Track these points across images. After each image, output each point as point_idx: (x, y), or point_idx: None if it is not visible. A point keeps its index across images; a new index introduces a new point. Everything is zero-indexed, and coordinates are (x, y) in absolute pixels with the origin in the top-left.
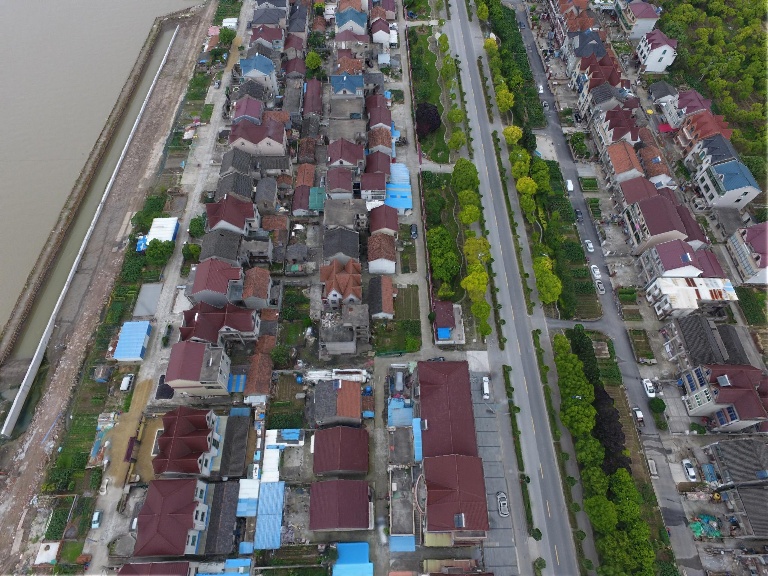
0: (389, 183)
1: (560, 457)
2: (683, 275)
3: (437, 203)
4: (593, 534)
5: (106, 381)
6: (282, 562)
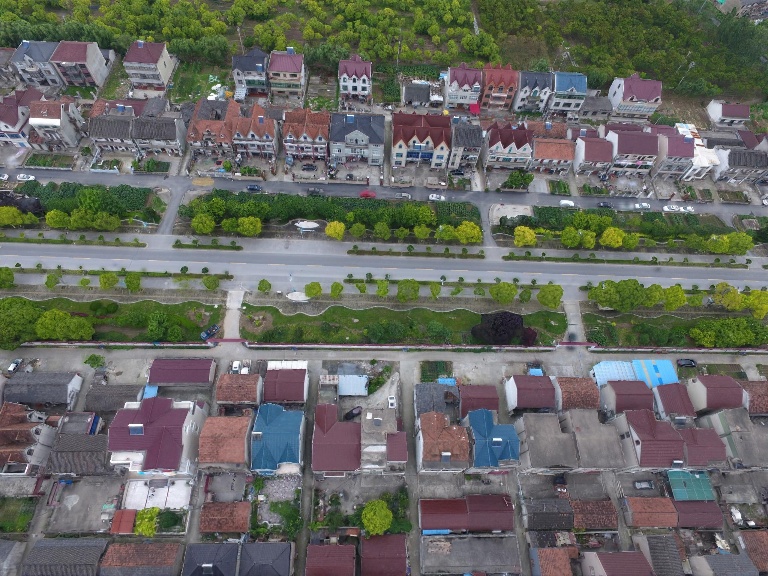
0: None
1: None
2: None
3: (659, 331)
4: None
5: None
6: None
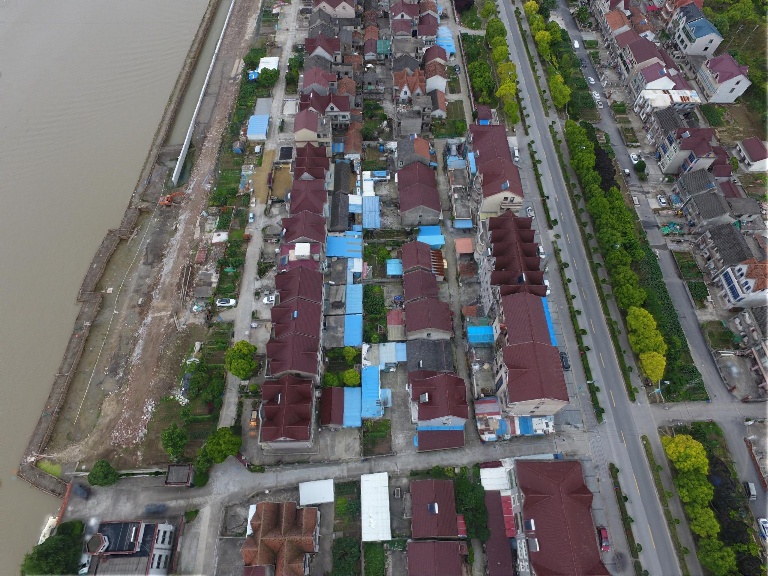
0: (437, 38)
1: (570, 189)
2: (661, 88)
3: (475, 49)
4: (593, 229)
5: (241, 152)
6: None
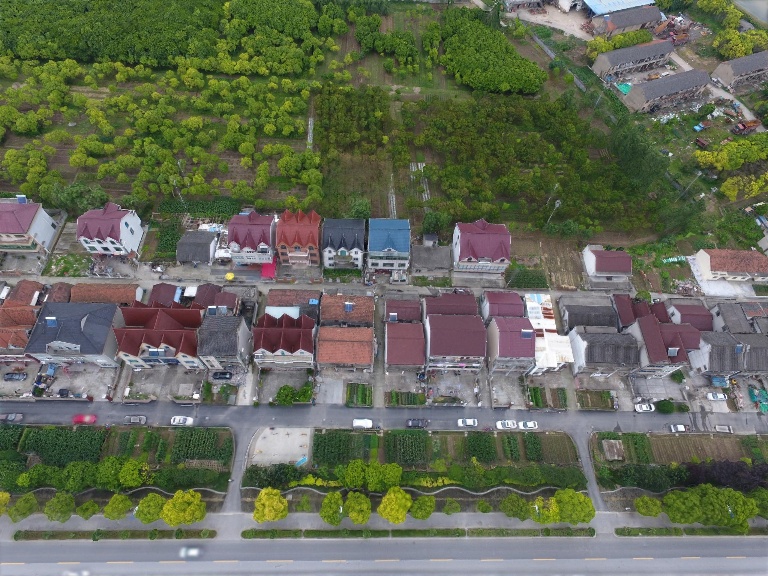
0: None
1: None
2: None
3: None
4: None
5: None
6: None
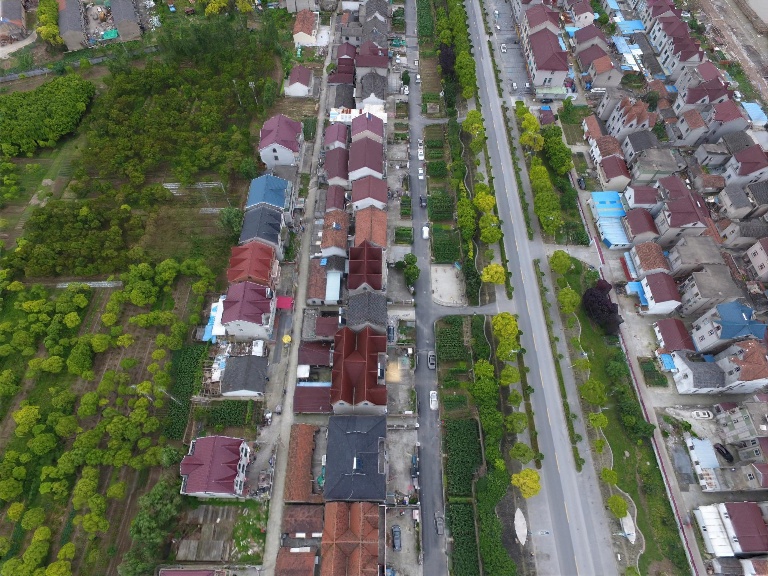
0: None
1: None
2: None
3: (570, 192)
4: None
5: None
6: None
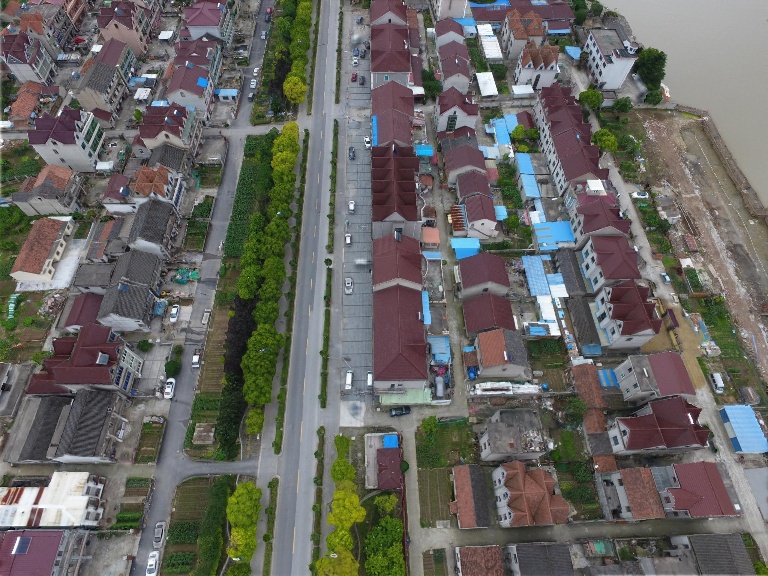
0: None
1: None
2: None
3: None
4: None
5: None
6: (516, 254)
